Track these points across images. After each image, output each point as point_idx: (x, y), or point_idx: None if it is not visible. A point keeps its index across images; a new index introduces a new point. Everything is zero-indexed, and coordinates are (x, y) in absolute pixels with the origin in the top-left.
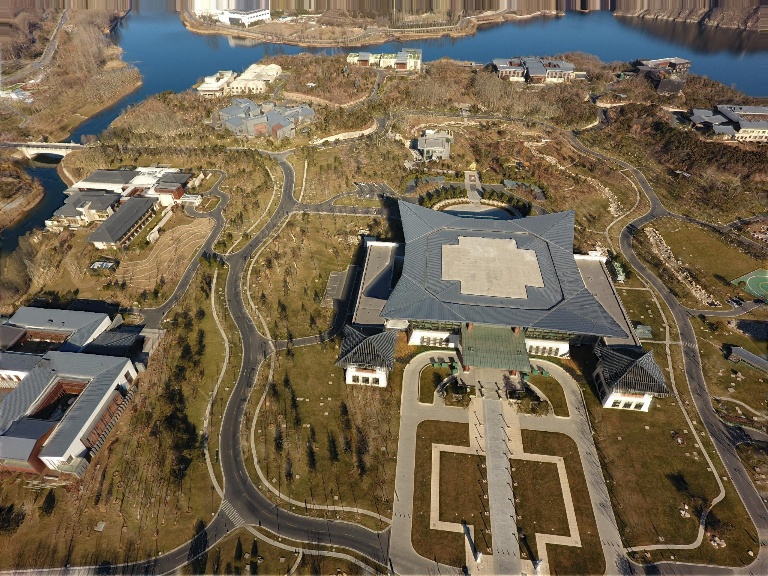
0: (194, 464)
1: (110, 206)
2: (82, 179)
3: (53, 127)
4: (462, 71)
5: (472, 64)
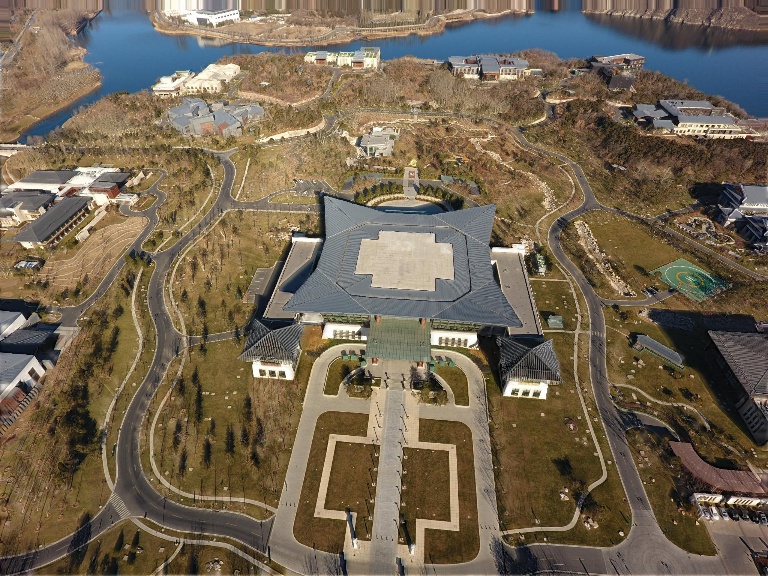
0: (89, 458)
1: (43, 206)
2: (19, 180)
3: (3, 128)
4: (419, 69)
5: (434, 62)
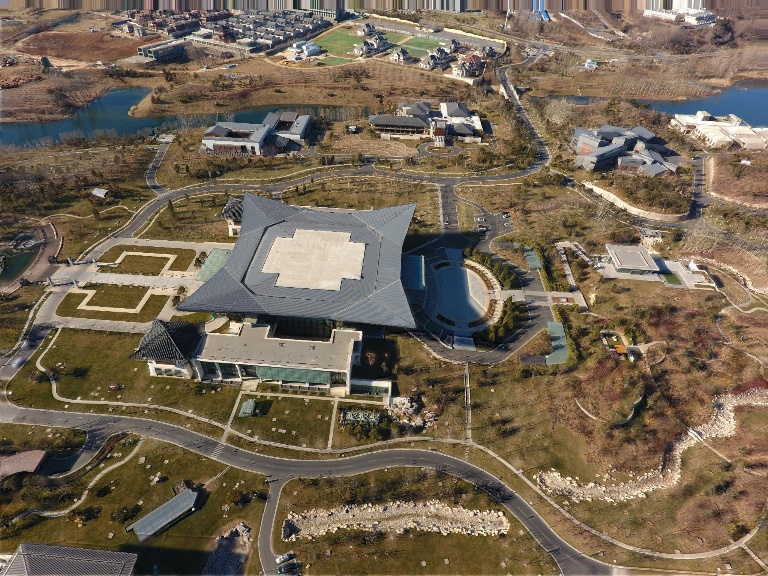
0: (198, 179)
1: None
2: None
3: (547, 88)
4: None
5: None
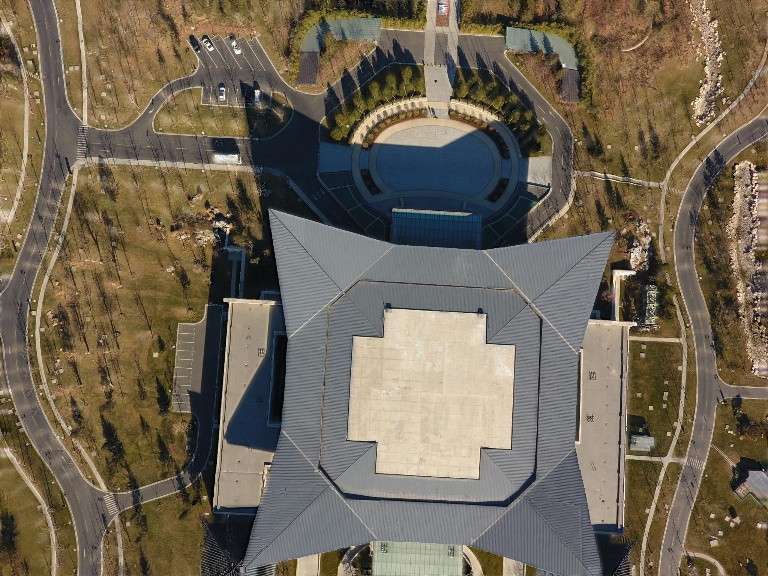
0: None
1: None
2: None
3: None
4: None
5: None
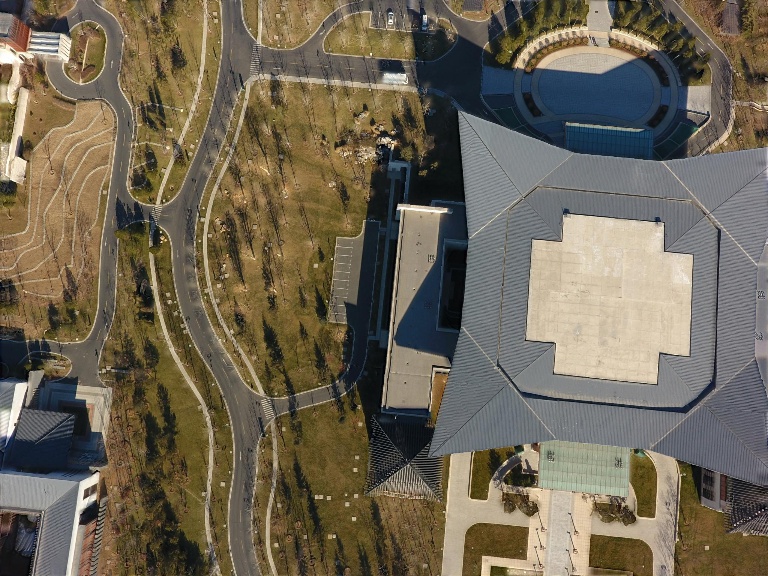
0: None
1: None
2: None
3: None
4: None
5: None
